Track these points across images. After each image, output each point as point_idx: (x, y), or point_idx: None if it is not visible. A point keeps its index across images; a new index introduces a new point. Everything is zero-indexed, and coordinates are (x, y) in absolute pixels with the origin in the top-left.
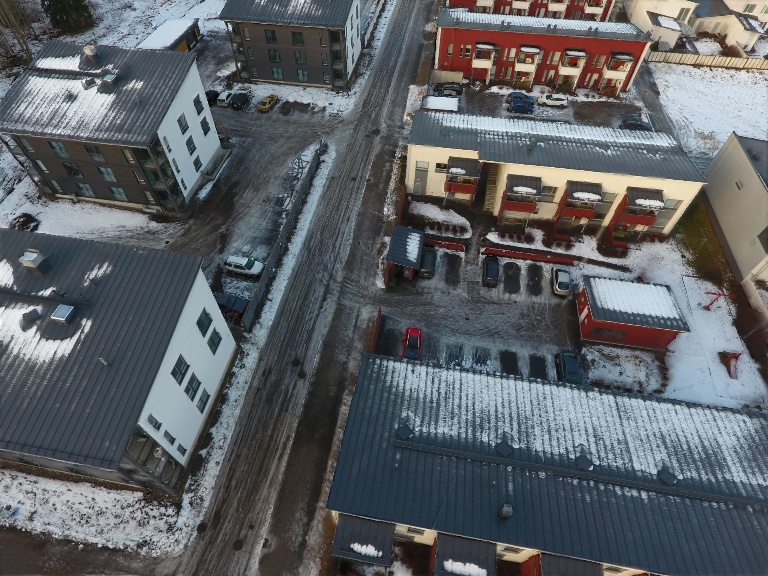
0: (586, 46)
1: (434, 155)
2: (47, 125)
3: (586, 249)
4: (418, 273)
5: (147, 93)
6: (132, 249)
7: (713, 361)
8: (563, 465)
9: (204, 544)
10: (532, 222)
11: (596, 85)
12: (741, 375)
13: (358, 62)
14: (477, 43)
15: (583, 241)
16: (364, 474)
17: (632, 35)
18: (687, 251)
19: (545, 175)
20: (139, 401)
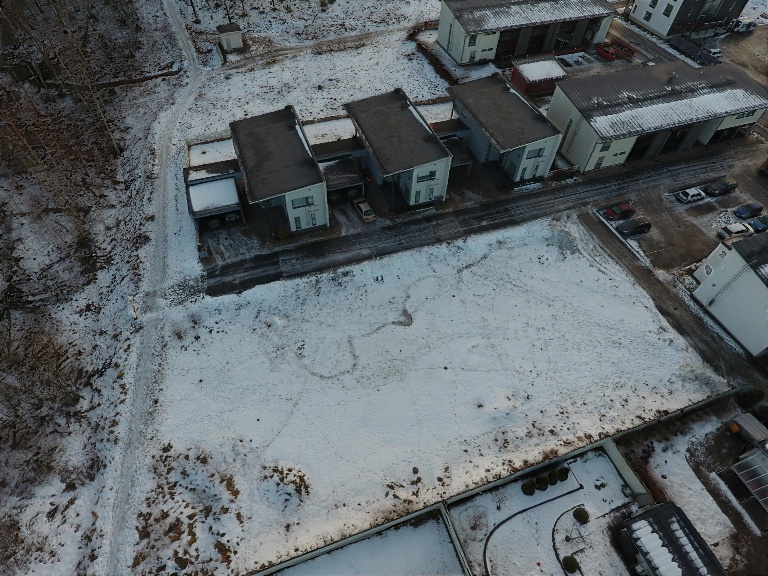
0: None
1: None
2: None
3: None
4: None
5: None
6: None
7: None
8: (537, 1)
9: None
10: None
11: None
12: None
13: None
14: None
15: None
16: None
17: None
18: None
19: None
20: None
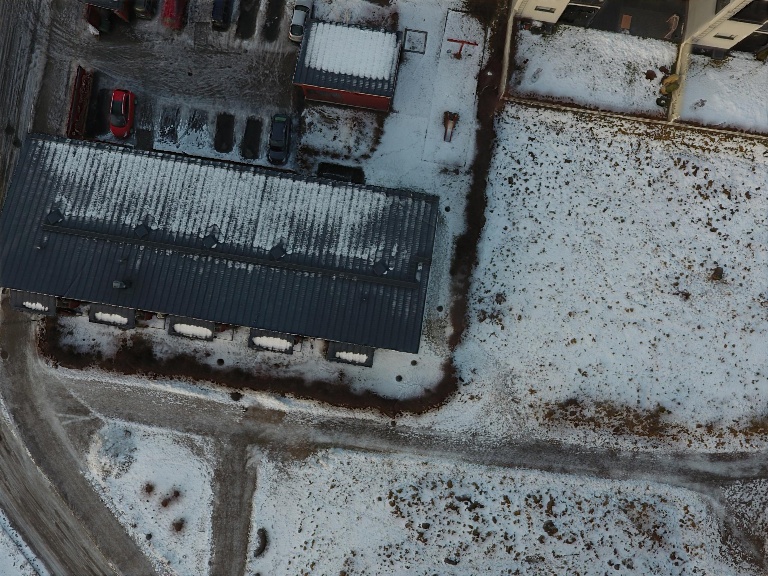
0: None
1: None
2: None
3: None
4: (134, 13)
5: None
6: None
7: (435, 122)
8: (190, 244)
9: None
10: None
11: None
12: (456, 137)
13: None
14: None
15: None
16: (13, 255)
17: None
18: None
19: None
20: None
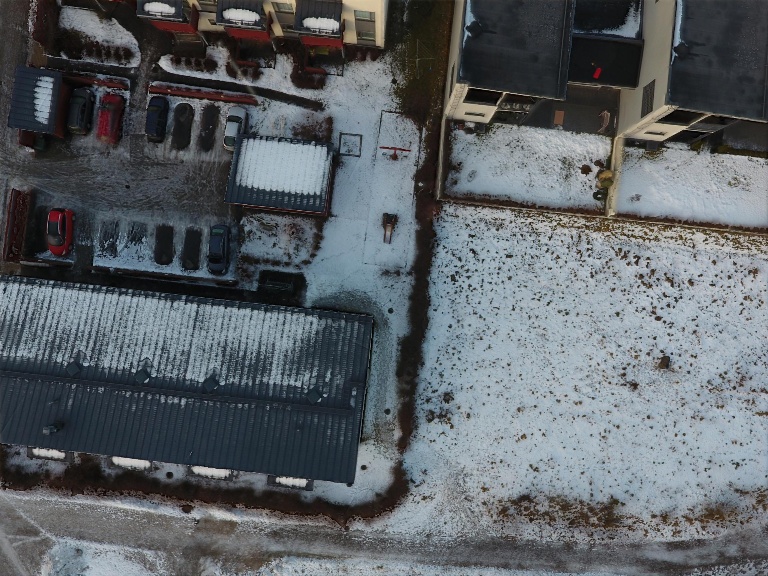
0: None
1: None
2: None
3: (277, 77)
4: (68, 130)
5: None
6: None
7: (374, 224)
8: (122, 380)
9: None
10: (212, 38)
11: None
12: (396, 239)
13: None
14: None
15: (275, 65)
16: None
17: None
18: (401, 72)
19: None
20: None
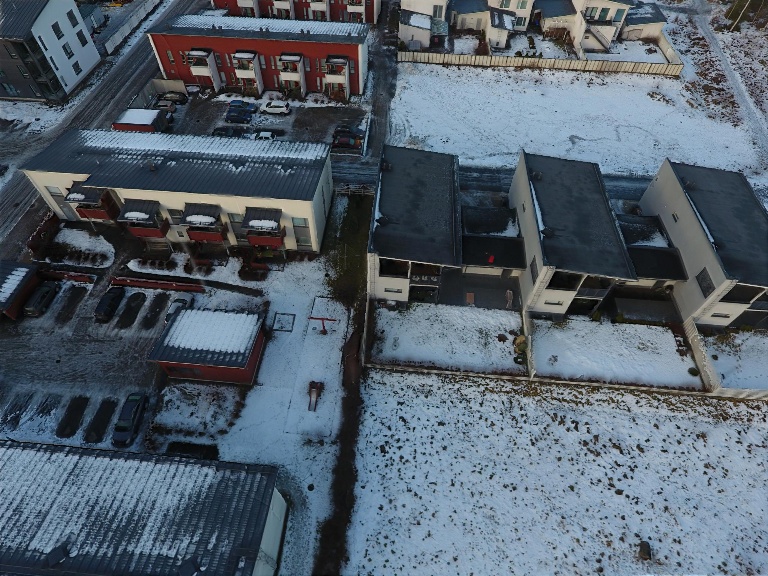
0: (302, 50)
1: (57, 180)
2: None
3: (226, 273)
4: (22, 312)
5: None
6: None
7: (300, 392)
8: None
9: None
10: (178, 246)
11: None
12: (321, 406)
13: (93, 71)
14: (192, 49)
15: (226, 264)
16: None
17: (347, 37)
18: (333, 269)
19: (160, 198)
20: None
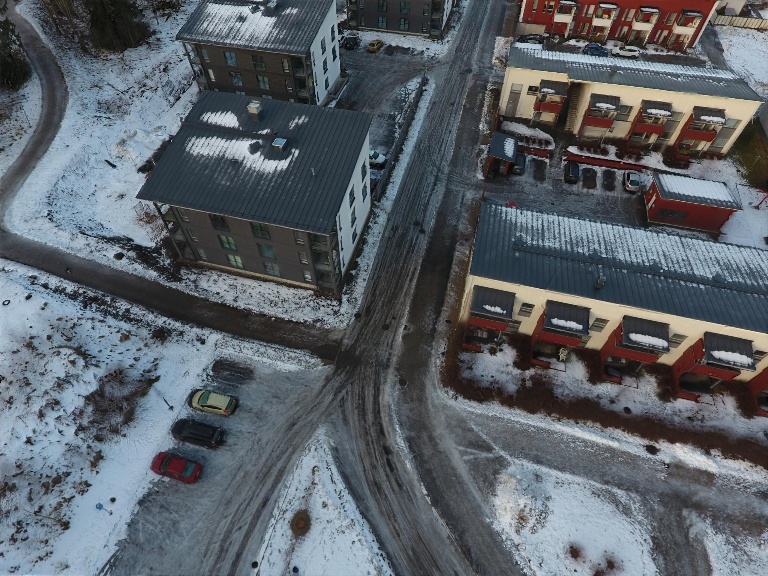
0: (659, 4)
1: (528, 78)
2: (226, 38)
3: (653, 161)
4: (512, 170)
5: (301, 17)
6: (321, 108)
7: (759, 242)
8: None
9: (361, 324)
10: (607, 139)
11: (665, 41)
12: None
13: (449, 18)
14: None
15: (651, 155)
16: (494, 260)
17: None
18: (742, 167)
19: (624, 95)
20: (339, 197)
